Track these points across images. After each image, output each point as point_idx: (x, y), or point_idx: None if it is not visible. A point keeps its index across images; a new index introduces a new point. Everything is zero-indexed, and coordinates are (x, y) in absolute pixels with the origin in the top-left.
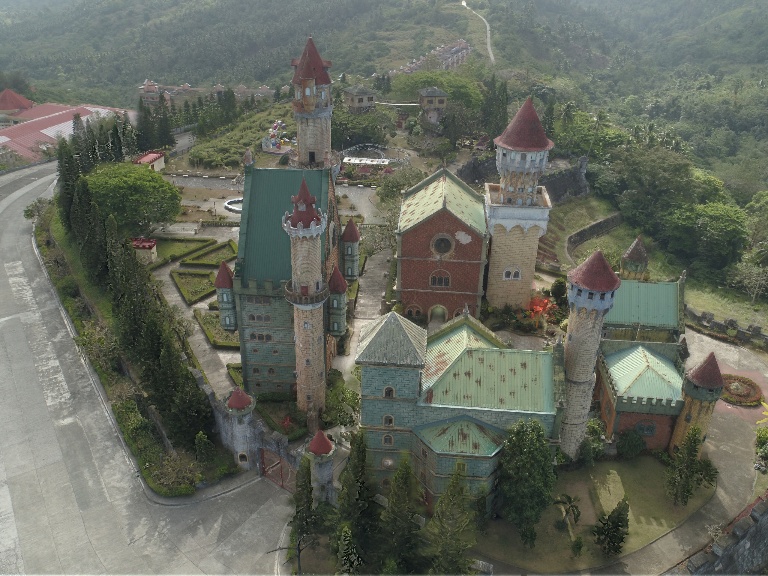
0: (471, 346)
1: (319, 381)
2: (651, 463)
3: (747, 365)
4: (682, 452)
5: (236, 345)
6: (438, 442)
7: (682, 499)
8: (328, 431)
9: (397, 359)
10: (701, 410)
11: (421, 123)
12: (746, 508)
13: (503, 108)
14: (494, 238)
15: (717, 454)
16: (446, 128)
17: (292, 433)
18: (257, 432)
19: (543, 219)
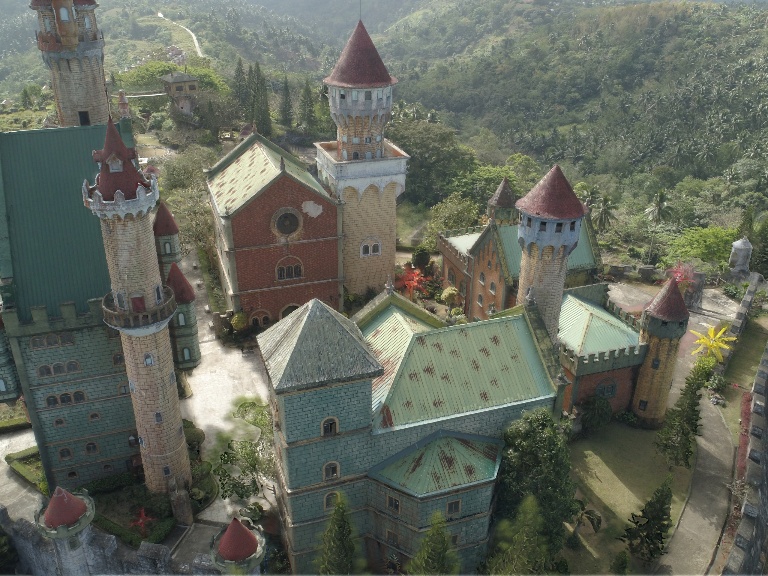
0: (416, 331)
1: (178, 442)
2: (619, 429)
3: (635, 299)
4: (680, 404)
5: (11, 424)
6: (416, 481)
7: (686, 462)
8: (205, 512)
9: (340, 371)
10: (670, 350)
11: (172, 115)
12: (736, 451)
13: (263, 90)
14: (344, 206)
15: (670, 399)
16: (202, 119)
17: (153, 533)
18: (108, 553)
19: (400, 172)
